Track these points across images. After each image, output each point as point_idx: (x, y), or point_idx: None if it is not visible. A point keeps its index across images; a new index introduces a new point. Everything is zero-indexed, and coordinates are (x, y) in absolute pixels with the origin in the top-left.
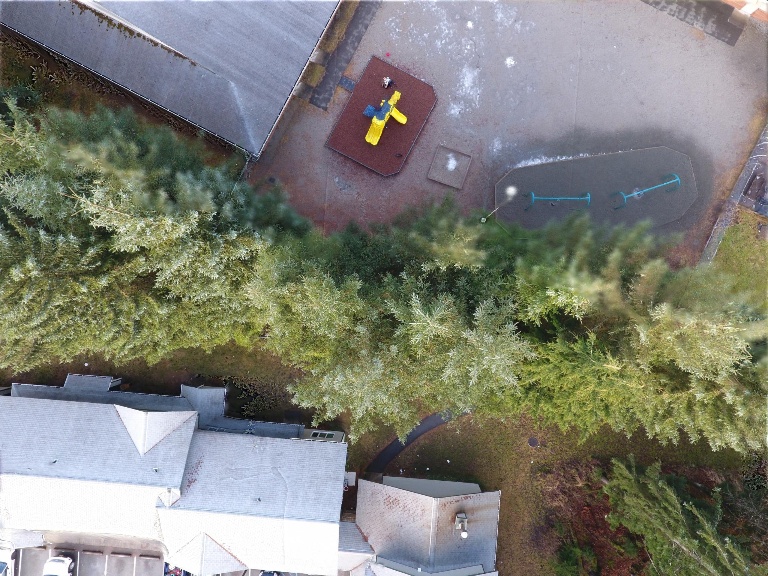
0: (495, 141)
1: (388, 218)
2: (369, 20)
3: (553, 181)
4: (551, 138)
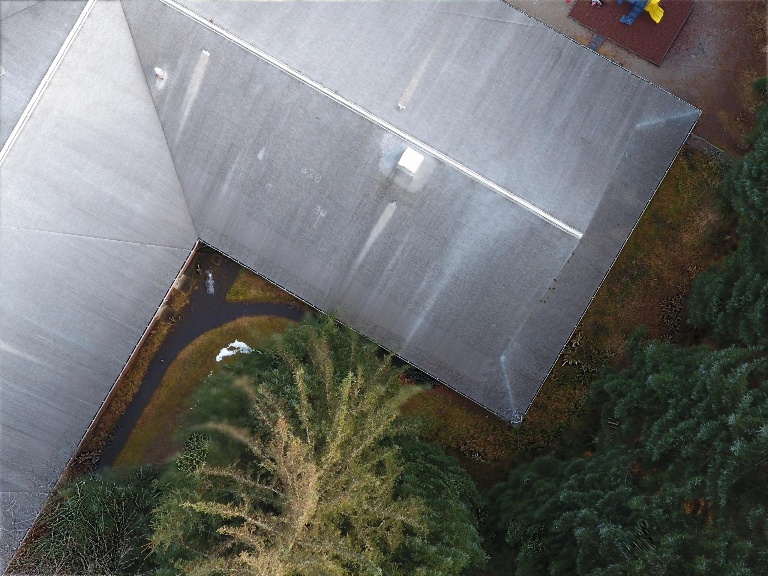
0: None
1: (734, 7)
2: None
3: None
4: None
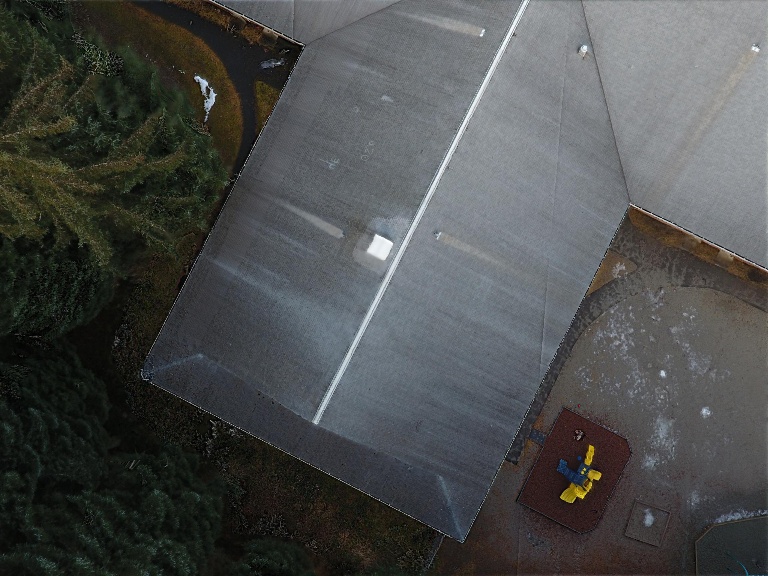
0: (693, 494)
1: (583, 574)
2: (558, 370)
3: (756, 538)
4: (751, 491)
